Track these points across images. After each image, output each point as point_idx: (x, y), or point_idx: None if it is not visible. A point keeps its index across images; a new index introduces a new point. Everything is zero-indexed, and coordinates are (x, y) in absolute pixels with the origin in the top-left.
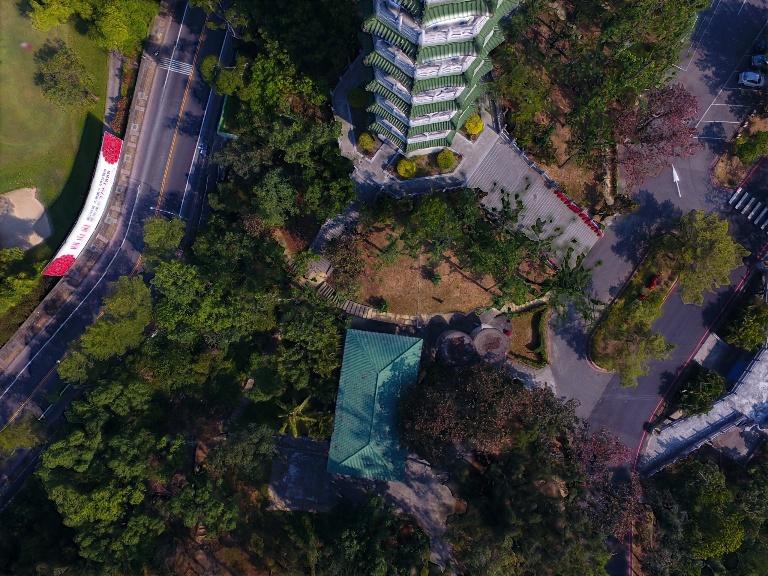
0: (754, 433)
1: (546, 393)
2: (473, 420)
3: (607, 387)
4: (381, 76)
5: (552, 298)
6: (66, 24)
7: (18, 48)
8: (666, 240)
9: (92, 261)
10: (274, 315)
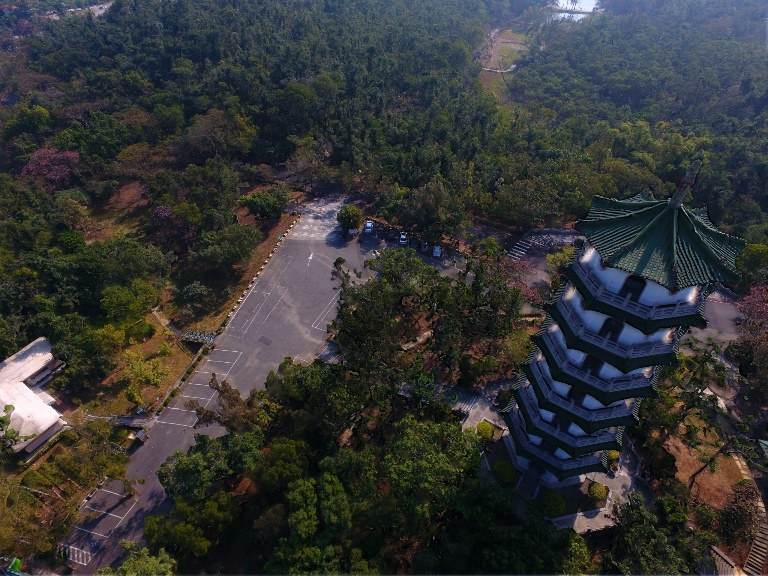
0: None
1: (744, 341)
2: None
3: None
4: None
5: None
6: None
7: None
8: None
9: None
10: None
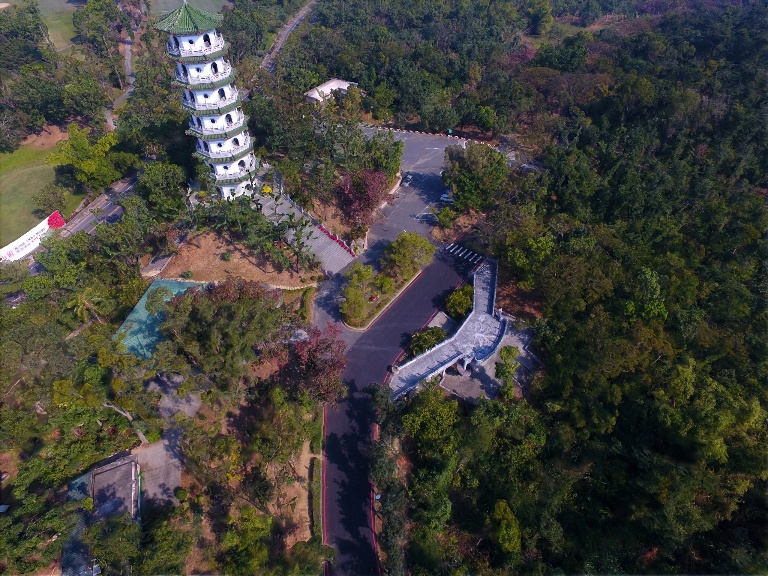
0: (492, 386)
1: None
2: None
3: (357, 341)
4: None
5: (318, 287)
6: (68, 193)
7: None
8: (386, 244)
9: None
10: (111, 288)
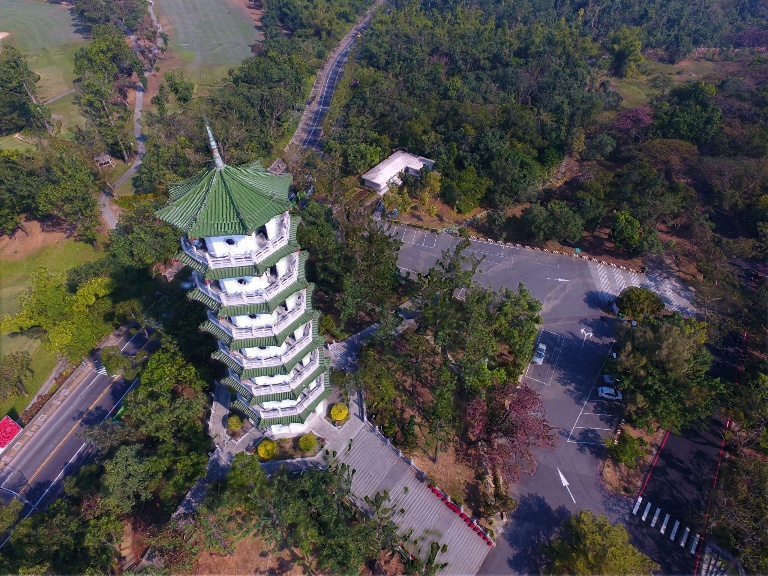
0: None
1: None
2: None
3: None
4: (223, 345)
5: None
6: (40, 342)
7: None
8: (557, 546)
9: None
10: None
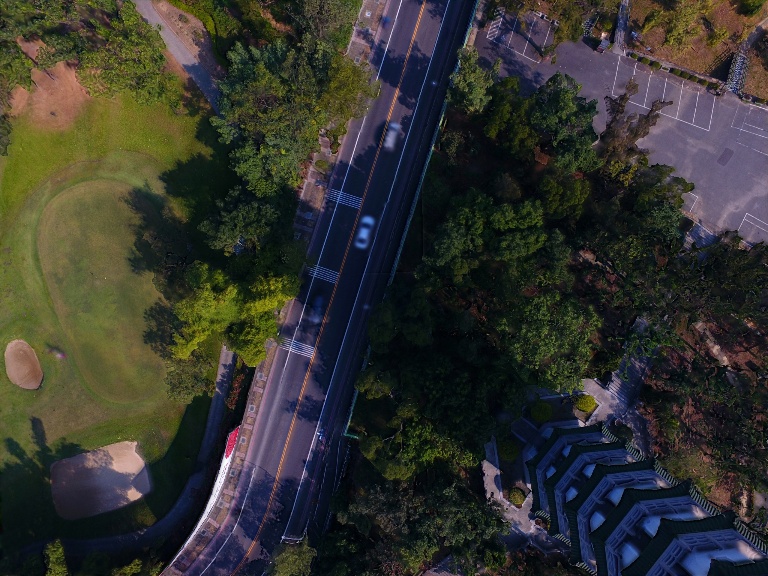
0: None
1: None
2: None
3: None
4: (593, 567)
5: None
6: None
7: (128, 305)
8: None
9: (201, 546)
10: None
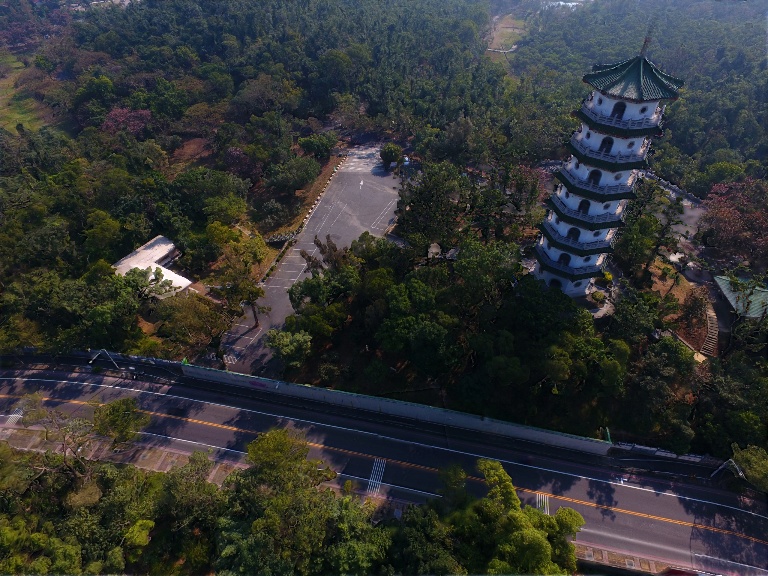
0: None
1: (706, 219)
2: (761, 229)
3: (665, 219)
4: None
5: None
6: None
7: None
8: None
9: None
10: None
